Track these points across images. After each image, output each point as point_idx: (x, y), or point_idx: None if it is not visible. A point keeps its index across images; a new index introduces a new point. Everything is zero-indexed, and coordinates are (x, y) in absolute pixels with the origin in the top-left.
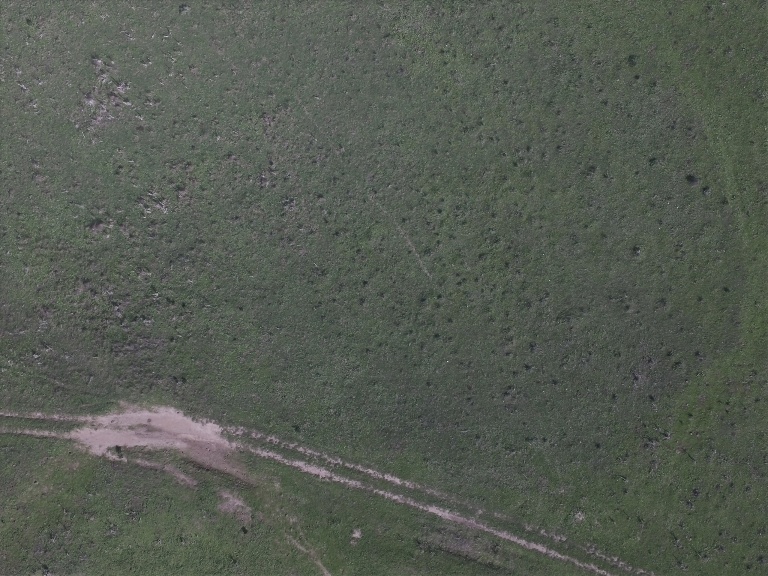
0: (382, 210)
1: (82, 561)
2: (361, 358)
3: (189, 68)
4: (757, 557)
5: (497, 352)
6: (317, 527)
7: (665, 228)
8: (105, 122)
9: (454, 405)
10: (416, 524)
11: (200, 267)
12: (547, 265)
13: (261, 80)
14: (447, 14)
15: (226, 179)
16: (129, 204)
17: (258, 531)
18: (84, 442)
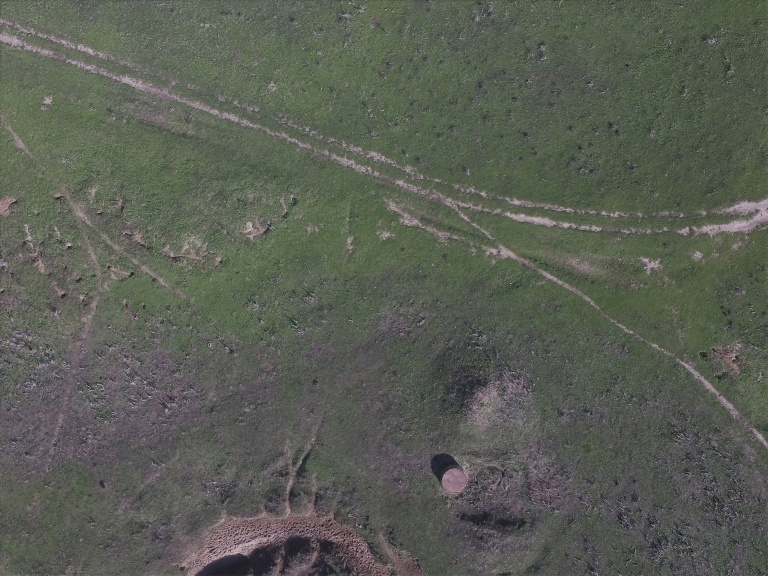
0: None
1: None
2: None
3: None
4: (448, 127)
5: None
6: (7, 93)
7: None
8: None
9: None
10: (109, 94)
11: None
12: None
13: None
14: None
15: None
16: None
17: None
18: None
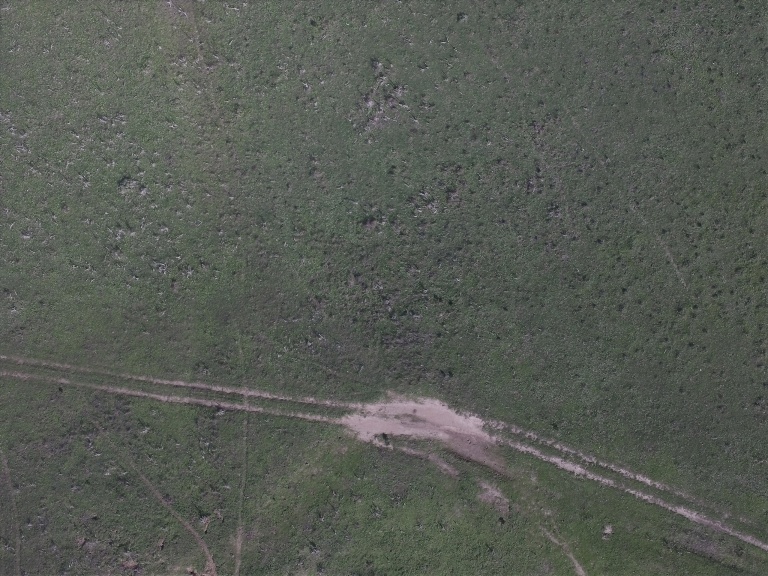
0: (643, 220)
1: (348, 541)
2: (618, 362)
3: (464, 74)
4: None
5: (749, 363)
6: (571, 522)
7: None
8: (381, 123)
9: (705, 412)
10: (664, 524)
11: (466, 267)
12: None
13: (532, 89)
14: (715, 33)
15: (494, 183)
16: (400, 203)
17: (515, 522)
18: (353, 428)
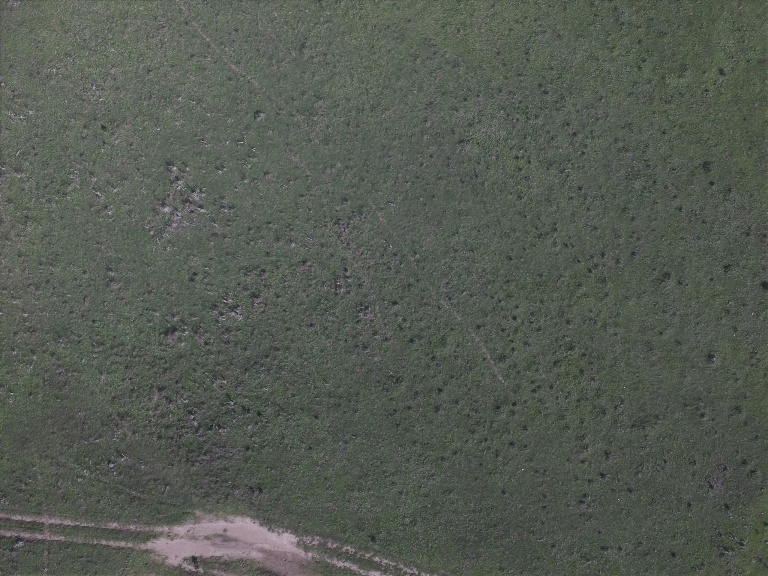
0: (457, 317)
1: None
2: (436, 466)
3: (264, 174)
4: None
5: (572, 460)
6: None
7: (740, 335)
8: (180, 228)
9: (529, 513)
10: None
11: (275, 375)
12: (622, 372)
13: (335, 186)
14: (521, 120)
15: (301, 286)
16: (204, 311)
17: None
18: (160, 553)
